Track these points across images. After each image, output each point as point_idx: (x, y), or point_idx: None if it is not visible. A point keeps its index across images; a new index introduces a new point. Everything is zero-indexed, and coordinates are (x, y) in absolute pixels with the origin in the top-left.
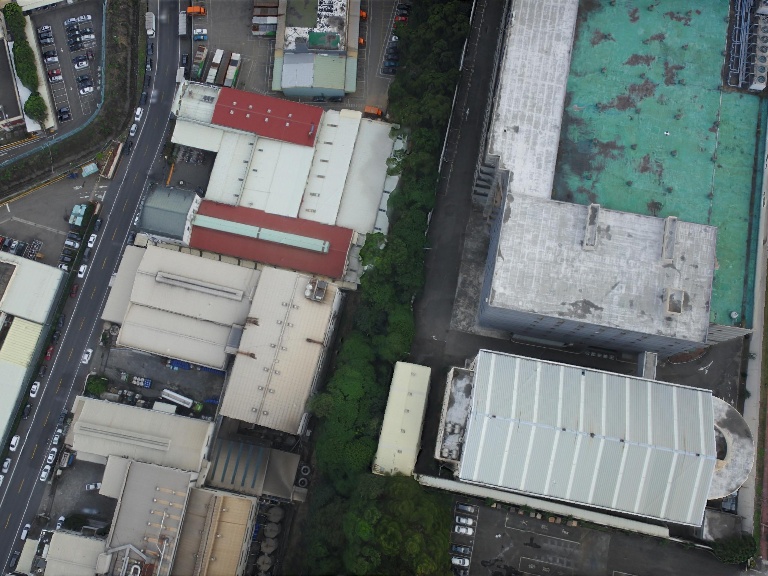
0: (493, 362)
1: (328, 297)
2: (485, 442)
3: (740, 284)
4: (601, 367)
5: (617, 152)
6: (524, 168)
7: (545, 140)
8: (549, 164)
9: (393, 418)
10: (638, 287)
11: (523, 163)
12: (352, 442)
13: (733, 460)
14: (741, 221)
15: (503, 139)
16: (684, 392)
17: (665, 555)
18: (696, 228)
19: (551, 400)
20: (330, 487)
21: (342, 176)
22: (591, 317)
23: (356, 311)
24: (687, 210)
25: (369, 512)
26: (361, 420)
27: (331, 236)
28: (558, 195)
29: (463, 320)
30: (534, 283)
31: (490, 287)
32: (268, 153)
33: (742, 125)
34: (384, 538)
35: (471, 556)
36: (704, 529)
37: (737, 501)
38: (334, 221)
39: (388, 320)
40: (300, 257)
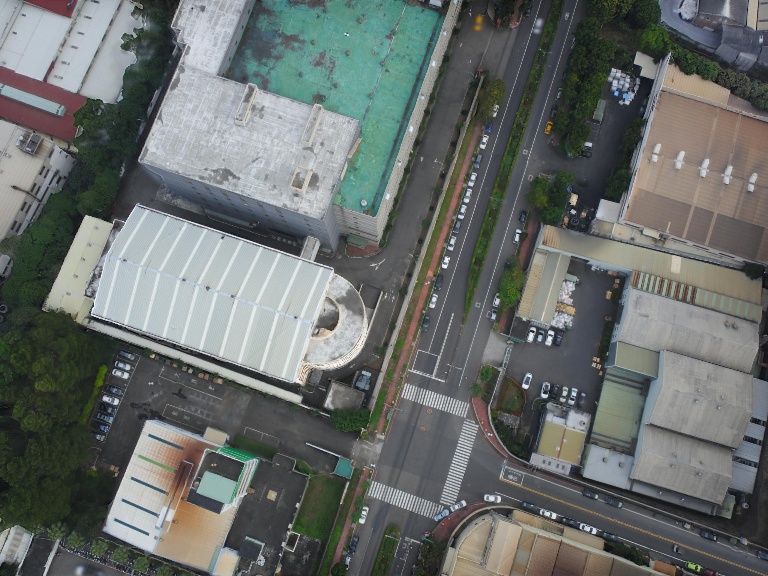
0: (144, 217)
1: (42, 152)
2: (116, 283)
3: (378, 177)
4: (282, 250)
5: (297, 45)
6: (201, 44)
7: (226, 22)
8: (224, 44)
9: (70, 264)
10: (276, 164)
11: (201, 40)
12: (32, 281)
13: (342, 333)
14: (394, 122)
15: (188, 16)
16: (308, 266)
17: (295, 419)
18: (341, 119)
19: (183, 255)
20: (10, 321)
21: (93, 49)
22: (227, 184)
23: (72, 170)
24: (347, 105)
25: (9, 333)
26: (45, 263)
27: (70, 102)
28: (235, 76)
29: (169, 192)
30: (184, 147)
31: (144, 146)
32: (30, 18)
33: (417, 36)
34: (15, 356)
35: (123, 397)
36: (327, 399)
37: (375, 384)
38: (77, 89)
39: (94, 181)
40: (38, 117)
